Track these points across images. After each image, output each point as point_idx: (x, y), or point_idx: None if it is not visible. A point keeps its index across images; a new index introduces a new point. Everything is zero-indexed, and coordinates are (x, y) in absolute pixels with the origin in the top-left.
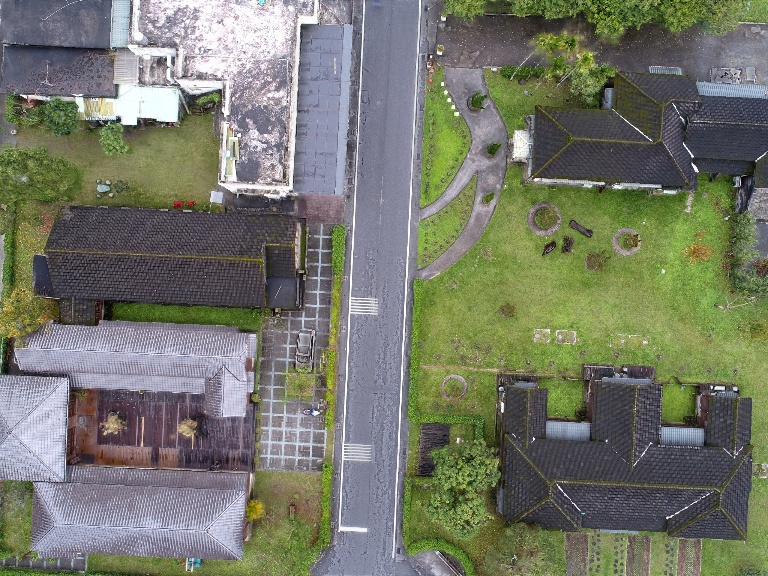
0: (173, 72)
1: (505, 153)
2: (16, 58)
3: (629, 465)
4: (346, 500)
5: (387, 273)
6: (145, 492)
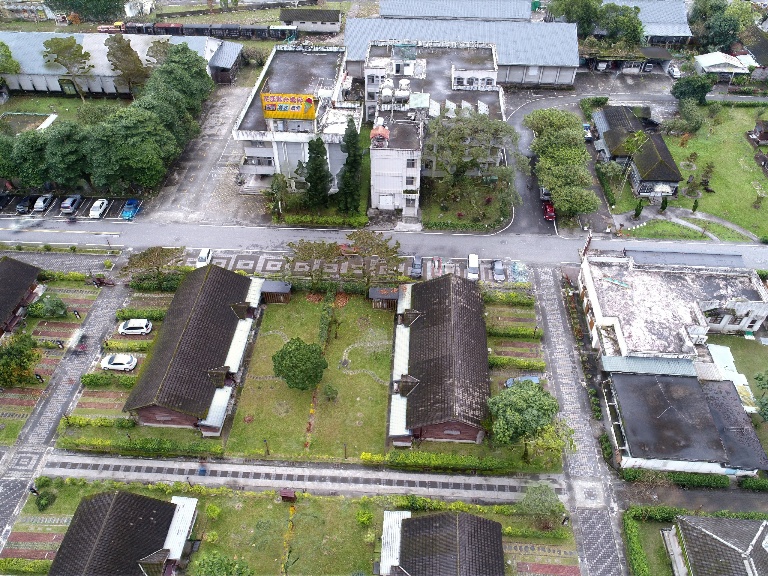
0: (696, 341)
1: (660, 206)
2: (733, 456)
3: None
4: None
5: (766, 254)
6: None
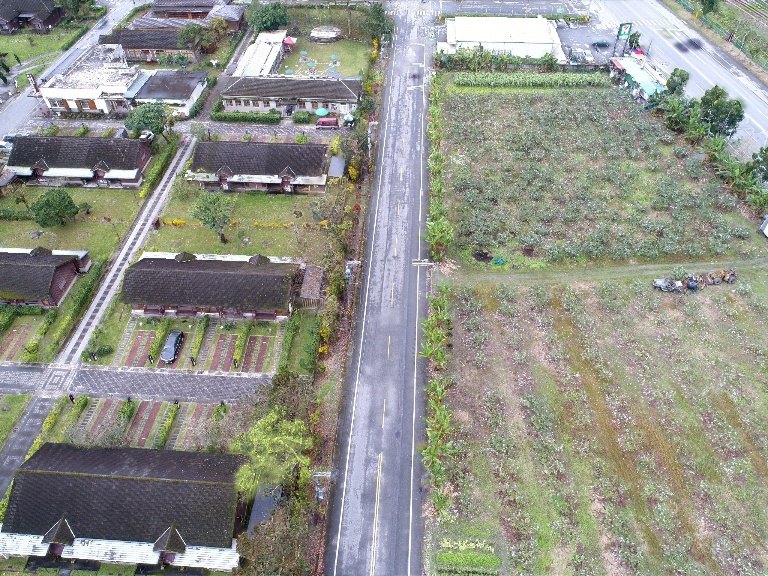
0: None
1: None
2: None
3: (9, 4)
4: (123, 16)
5: None
6: (186, 3)
